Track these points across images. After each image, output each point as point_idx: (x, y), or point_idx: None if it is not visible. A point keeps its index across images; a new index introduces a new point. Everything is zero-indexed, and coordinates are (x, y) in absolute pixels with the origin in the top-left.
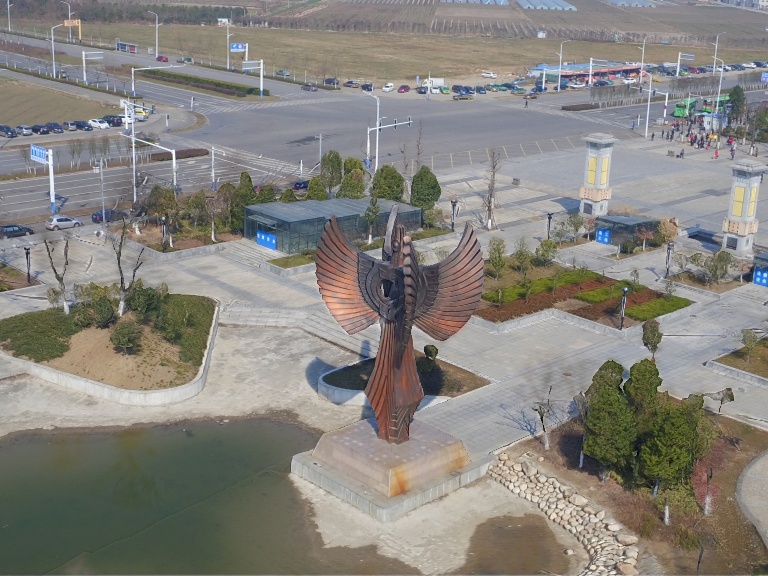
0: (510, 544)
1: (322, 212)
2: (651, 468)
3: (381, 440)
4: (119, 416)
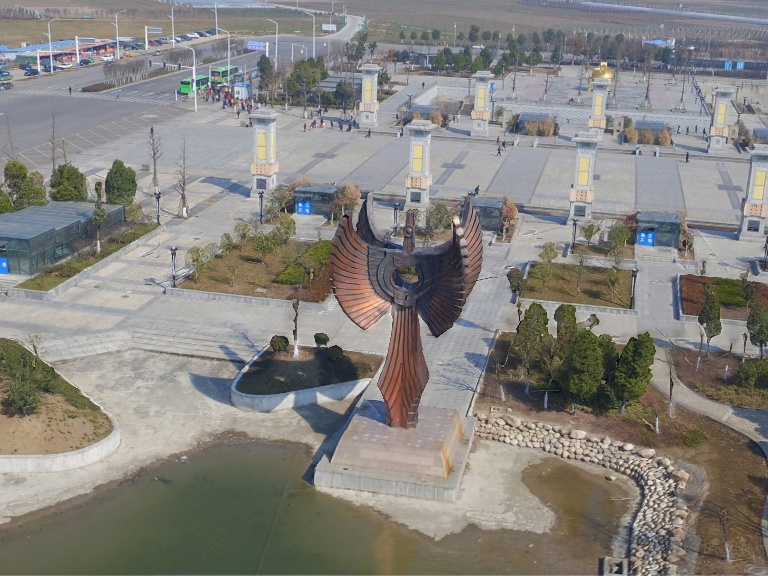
0: (563, 487)
1: (40, 224)
2: (632, 390)
3: (397, 428)
4: (68, 485)
